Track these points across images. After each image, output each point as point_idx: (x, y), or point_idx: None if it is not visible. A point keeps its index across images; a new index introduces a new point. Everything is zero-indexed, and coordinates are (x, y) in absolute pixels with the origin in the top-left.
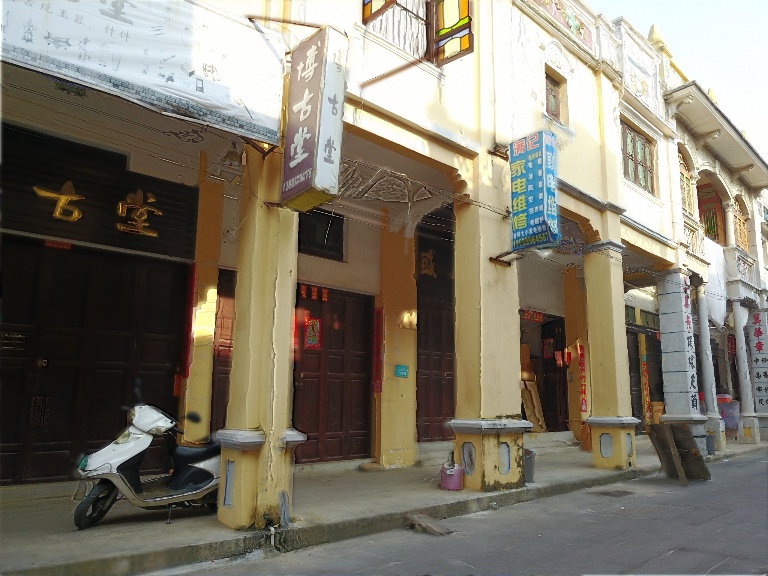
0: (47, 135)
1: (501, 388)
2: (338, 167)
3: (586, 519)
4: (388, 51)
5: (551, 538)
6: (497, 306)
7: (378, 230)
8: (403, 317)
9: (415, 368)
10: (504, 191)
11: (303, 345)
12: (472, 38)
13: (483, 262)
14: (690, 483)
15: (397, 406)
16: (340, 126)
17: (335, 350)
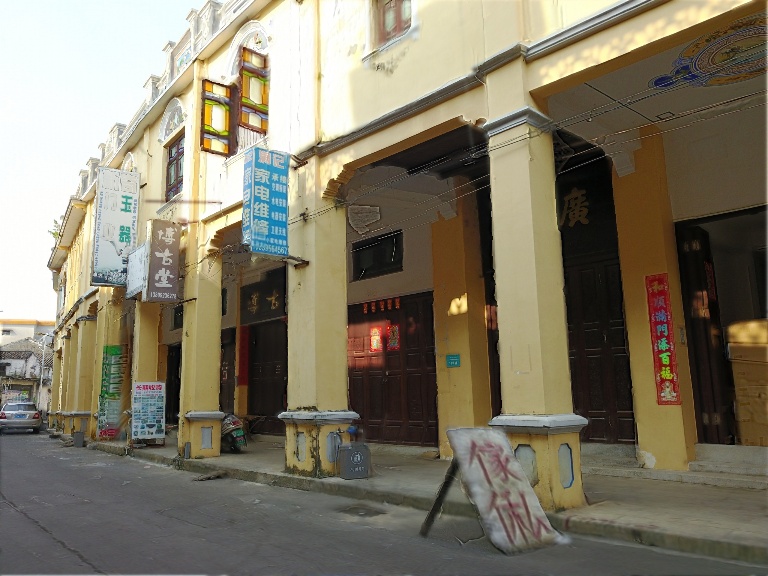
0: (271, 270)
1: (300, 382)
2: (147, 287)
3: (218, 498)
4: (237, 161)
5: (165, 492)
6: (299, 307)
7: (430, 225)
8: (450, 304)
9: (466, 356)
10: (307, 194)
11: (386, 349)
12: (237, 115)
13: (290, 272)
14: (429, 533)
15: (450, 397)
16: (148, 266)
17: (413, 348)
